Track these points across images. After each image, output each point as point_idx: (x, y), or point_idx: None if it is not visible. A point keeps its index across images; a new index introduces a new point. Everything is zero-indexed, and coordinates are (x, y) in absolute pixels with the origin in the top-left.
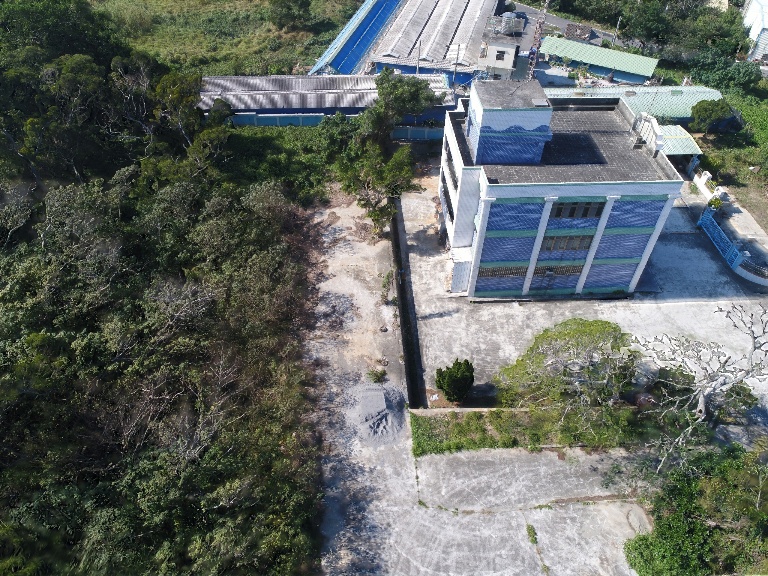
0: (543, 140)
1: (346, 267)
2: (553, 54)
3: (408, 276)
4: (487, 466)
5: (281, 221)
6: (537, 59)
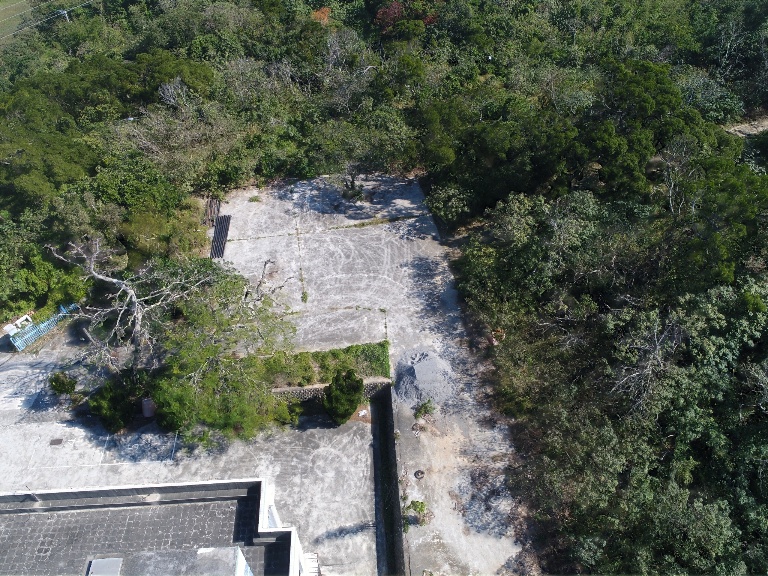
0: None
1: None
2: None
3: None
4: (326, 337)
5: None
6: None
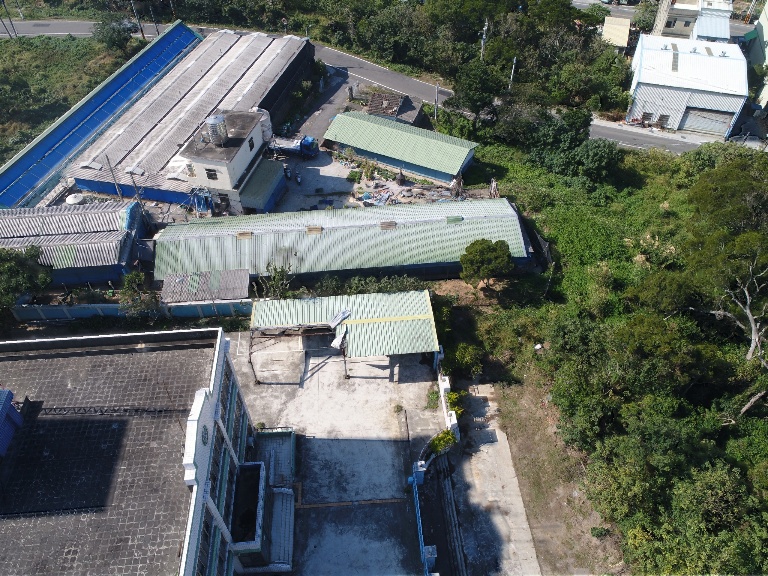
0: None
1: None
2: (335, 144)
3: None
4: None
5: None
6: (311, 153)
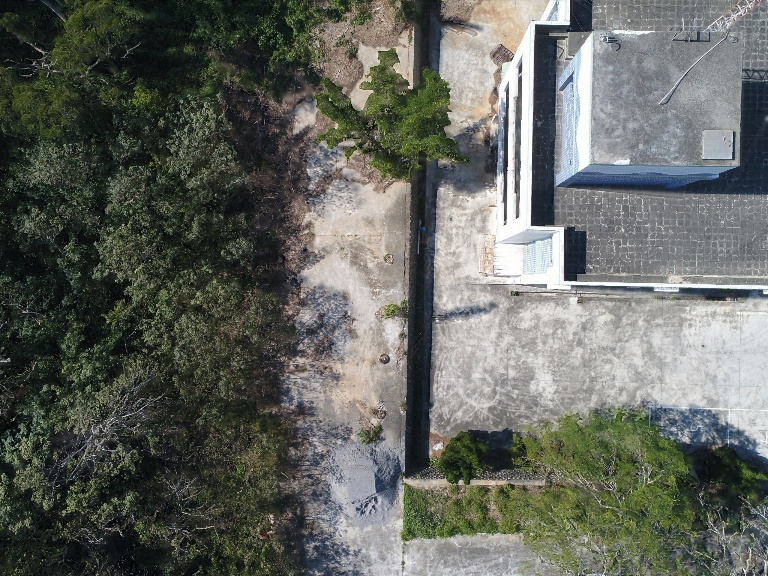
0: (696, 179)
1: (340, 239)
2: None
3: (431, 237)
4: (480, 555)
5: (242, 132)
6: None
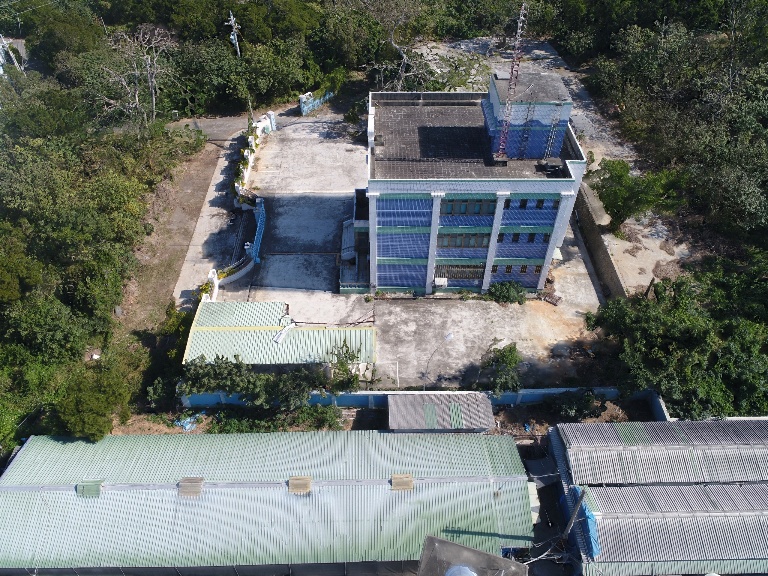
0: None
1: None
2: None
3: None
4: None
5: None
6: None
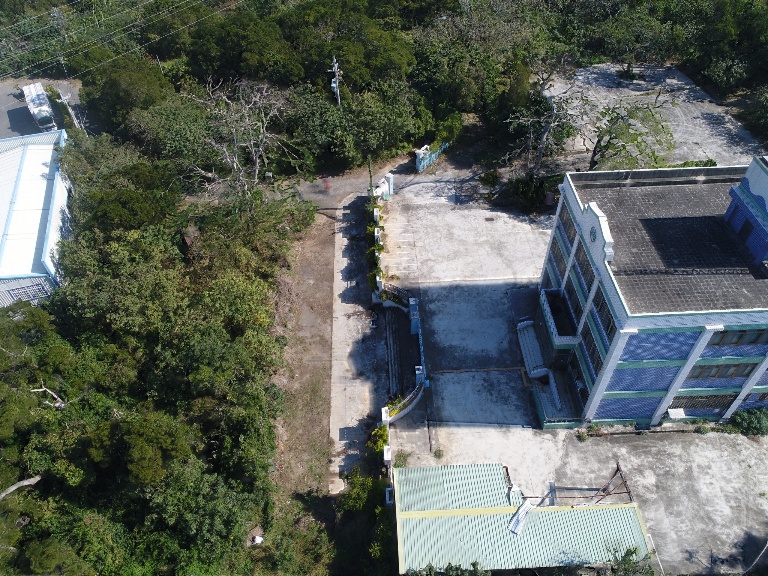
0: None
1: None
2: None
3: None
4: (662, 159)
5: None
6: None
